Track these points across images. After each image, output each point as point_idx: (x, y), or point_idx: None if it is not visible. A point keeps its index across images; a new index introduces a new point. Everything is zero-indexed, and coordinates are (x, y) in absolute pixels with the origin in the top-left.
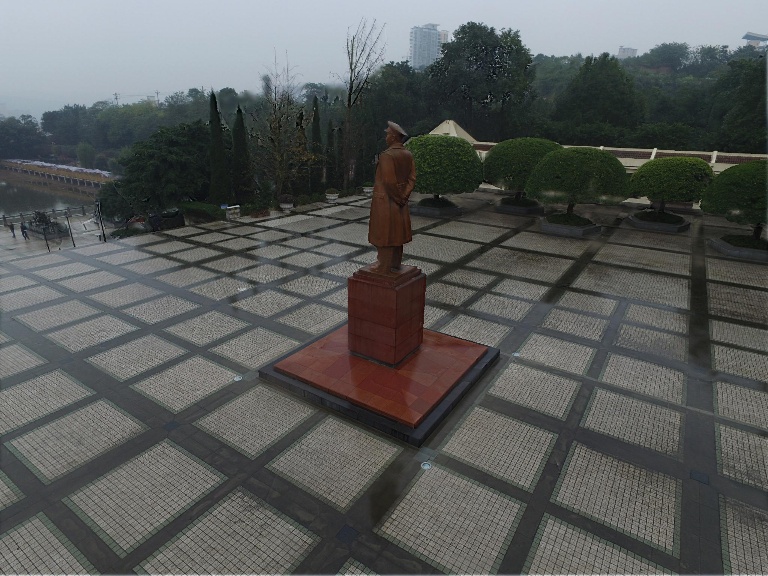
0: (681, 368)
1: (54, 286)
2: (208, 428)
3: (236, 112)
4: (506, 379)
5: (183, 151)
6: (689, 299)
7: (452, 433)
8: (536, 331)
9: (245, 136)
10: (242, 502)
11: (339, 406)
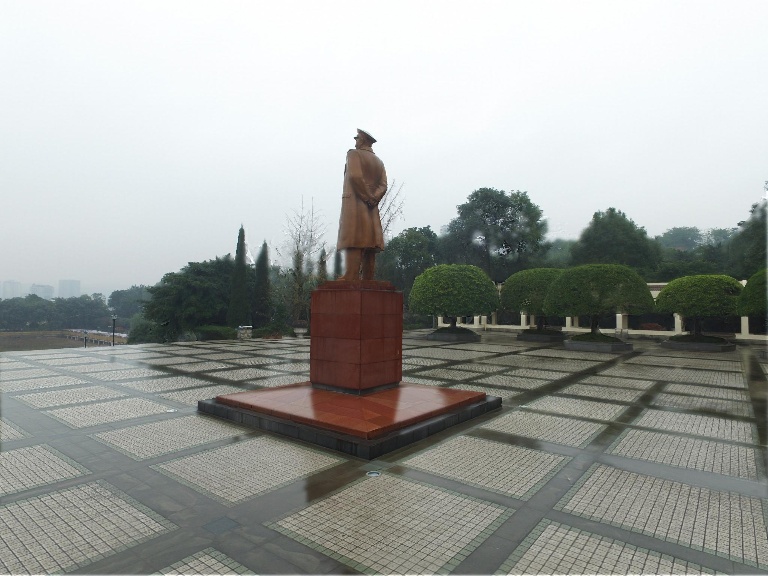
0: (746, 420)
1: (31, 362)
2: (104, 438)
3: (262, 246)
4: (506, 420)
5: (209, 280)
6: (745, 382)
7: (421, 452)
8: (551, 394)
9: (268, 267)
10: (92, 491)
11: (278, 424)
